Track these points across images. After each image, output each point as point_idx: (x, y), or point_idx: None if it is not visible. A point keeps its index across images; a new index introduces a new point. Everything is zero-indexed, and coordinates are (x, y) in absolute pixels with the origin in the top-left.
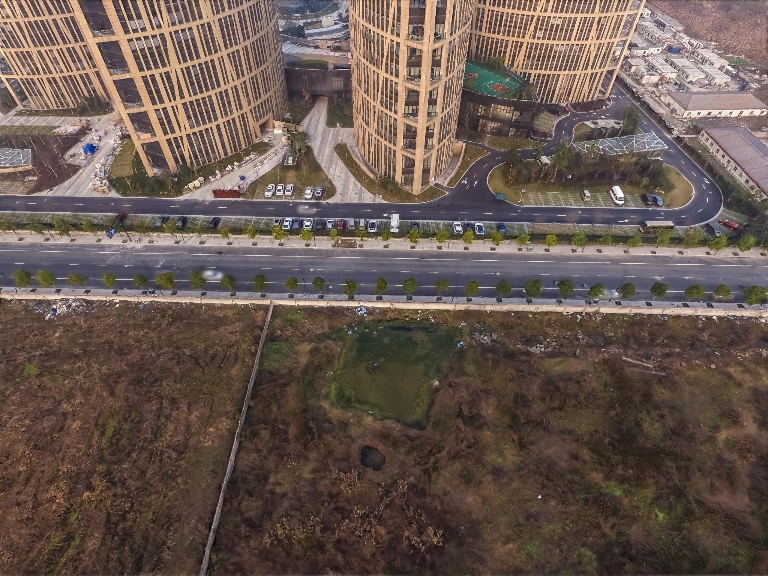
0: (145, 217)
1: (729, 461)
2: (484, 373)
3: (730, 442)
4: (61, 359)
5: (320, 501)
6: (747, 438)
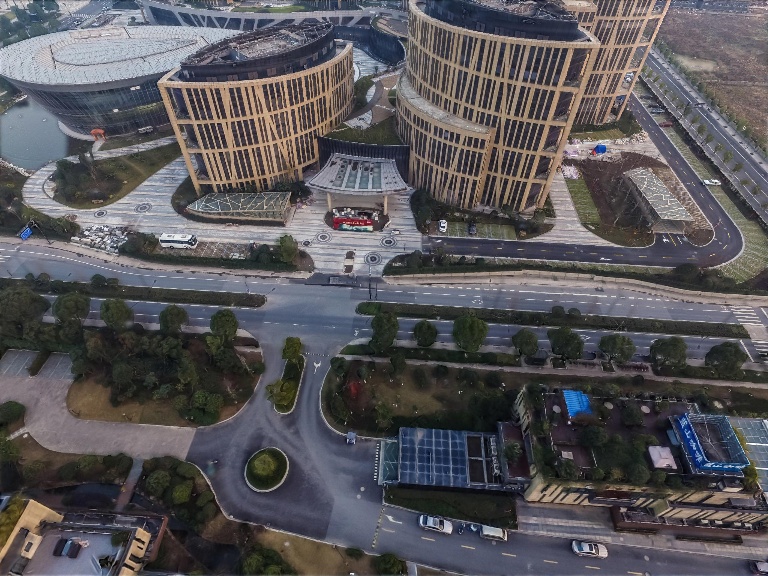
0: (657, 119)
1: (684, 27)
2: (686, 49)
3: (677, 26)
4: (767, 124)
5: (759, 73)
6: (674, 24)
